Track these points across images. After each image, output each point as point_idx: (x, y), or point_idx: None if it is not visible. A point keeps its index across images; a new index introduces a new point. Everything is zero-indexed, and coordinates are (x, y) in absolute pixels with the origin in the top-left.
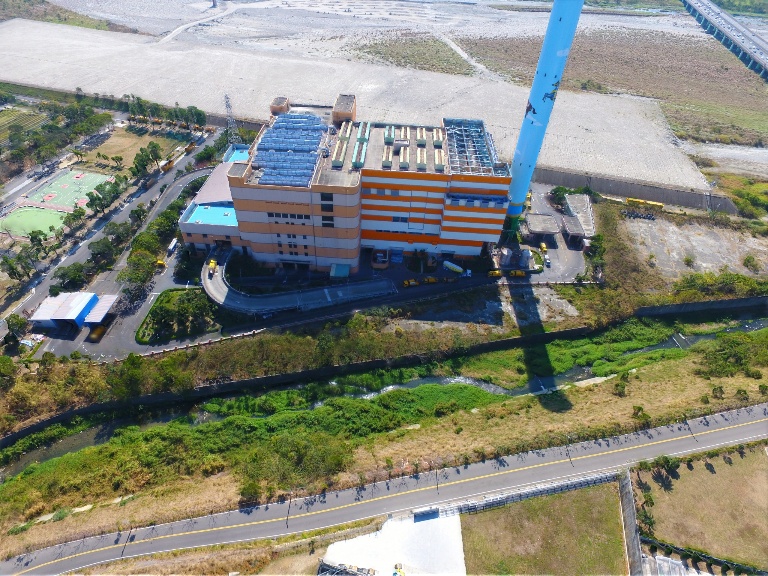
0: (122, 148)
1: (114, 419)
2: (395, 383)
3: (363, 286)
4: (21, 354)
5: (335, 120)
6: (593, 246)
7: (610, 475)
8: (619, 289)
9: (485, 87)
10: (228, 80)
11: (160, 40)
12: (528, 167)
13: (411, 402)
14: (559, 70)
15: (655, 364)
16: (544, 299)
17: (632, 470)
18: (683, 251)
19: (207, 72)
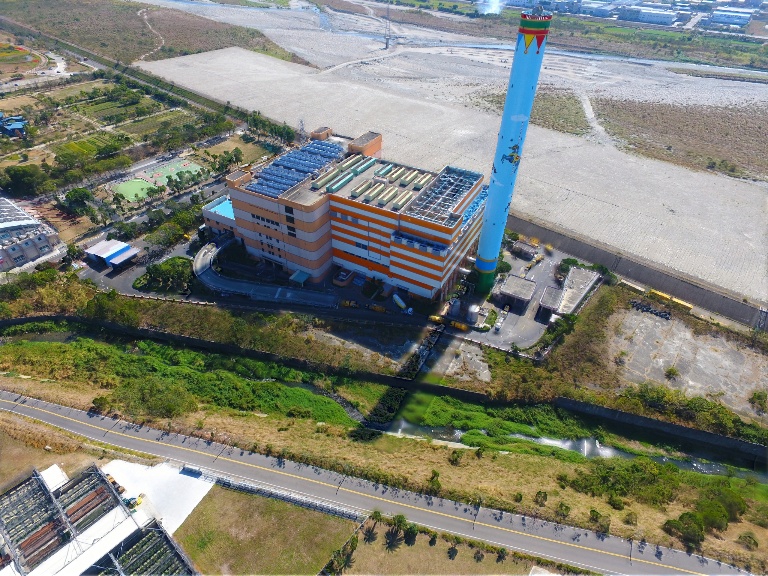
0: (227, 150)
1: (85, 331)
2: (278, 378)
3: (312, 295)
4: (67, 272)
5: (350, 152)
6: (556, 323)
7: (360, 516)
8: (555, 373)
9: (585, 149)
10: (345, 110)
11: (321, 72)
12: (492, 225)
13: (276, 396)
14: (515, 134)
15: (535, 456)
16: (465, 356)
17: (373, 517)
18: (675, 361)
19: (334, 101)
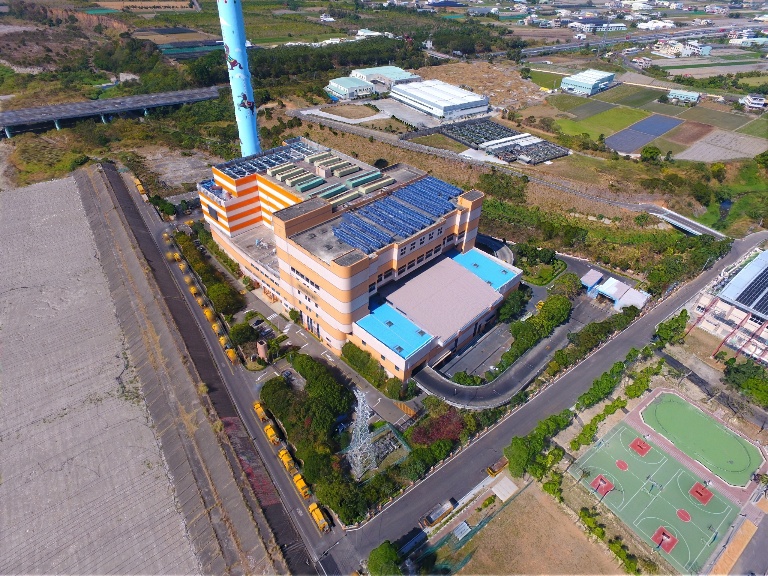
0: None
1: None
2: None
3: None
4: None
5: None
6: None
7: None
8: None
9: None
10: None
11: None
12: None
13: None
14: None
15: None
16: None
17: None
18: (198, 169)
19: None
